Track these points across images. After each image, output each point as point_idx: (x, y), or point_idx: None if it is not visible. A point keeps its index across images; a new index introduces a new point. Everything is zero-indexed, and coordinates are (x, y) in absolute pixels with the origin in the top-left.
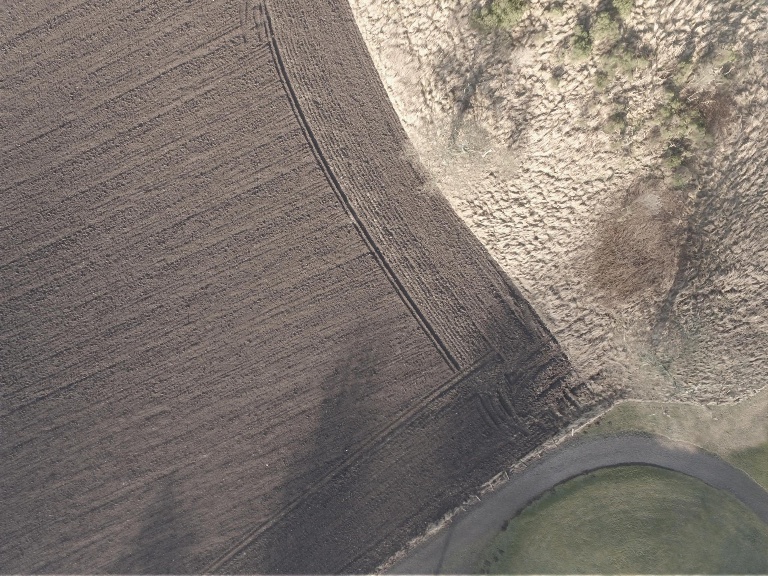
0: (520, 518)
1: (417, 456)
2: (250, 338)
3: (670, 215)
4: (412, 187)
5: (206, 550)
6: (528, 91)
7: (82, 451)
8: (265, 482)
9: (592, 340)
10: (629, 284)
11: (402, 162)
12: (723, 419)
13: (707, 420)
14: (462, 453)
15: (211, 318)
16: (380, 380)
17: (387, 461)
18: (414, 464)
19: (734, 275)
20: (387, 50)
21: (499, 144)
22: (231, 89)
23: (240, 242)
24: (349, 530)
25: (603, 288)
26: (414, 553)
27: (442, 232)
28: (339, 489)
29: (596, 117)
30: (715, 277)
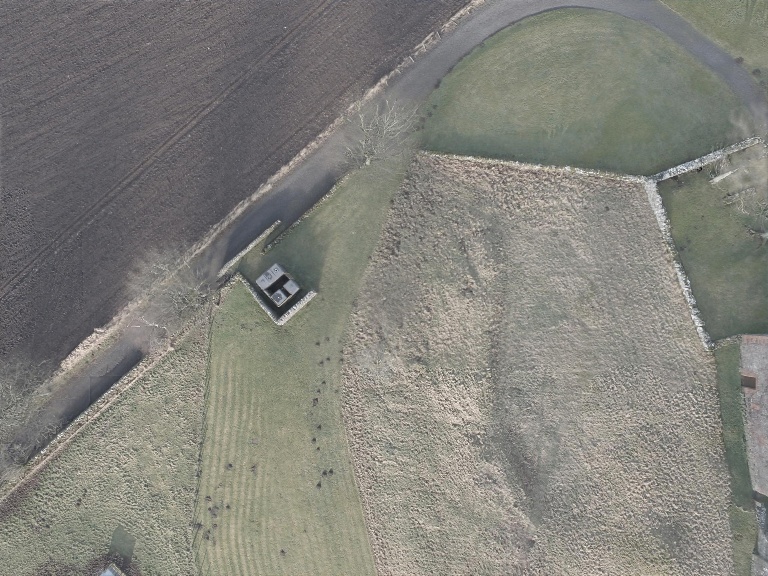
0: (452, 73)
1: (353, 26)
2: None
3: None
4: None
5: (151, 135)
6: None
7: (27, 48)
8: (207, 65)
9: None
10: None
11: None
12: None
13: None
14: (395, 19)
15: None
16: None
17: (324, 34)
18: (350, 34)
19: None
20: None
21: None
22: None
23: None
24: (290, 104)
25: None
26: (352, 120)
27: None
28: (279, 66)
29: None
30: None
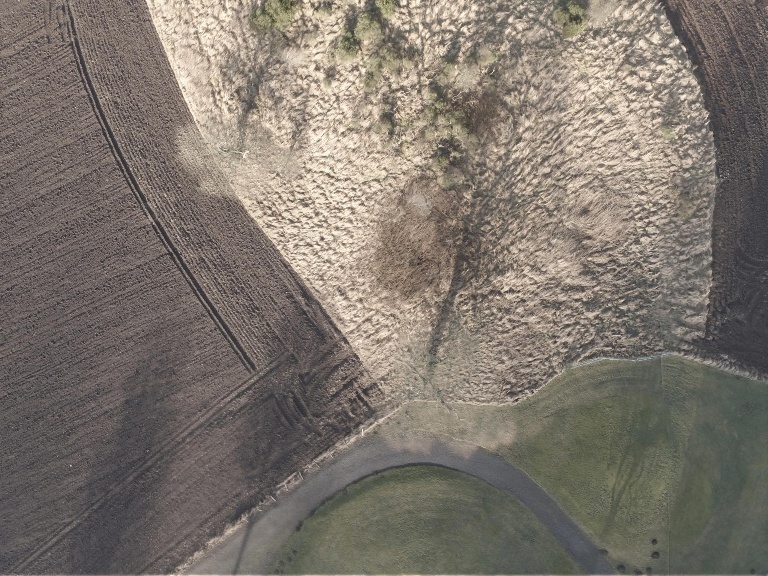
0: (313, 518)
1: (215, 456)
2: (54, 339)
3: (445, 215)
4: (207, 188)
5: (12, 551)
6: (305, 91)
7: None
8: (69, 483)
9: (380, 340)
10: (407, 284)
11: (197, 162)
12: (504, 419)
13: (489, 420)
14: (258, 453)
15: (16, 319)
16: (179, 381)
17: (187, 462)
18: (212, 464)
19: (511, 275)
20: (179, 50)
21: (282, 144)
22: (35, 89)
23: (44, 243)
24: (150, 530)
25: (385, 288)
26: (212, 553)
27: (236, 233)
28: (141, 490)
29: (367, 117)
30: (493, 277)
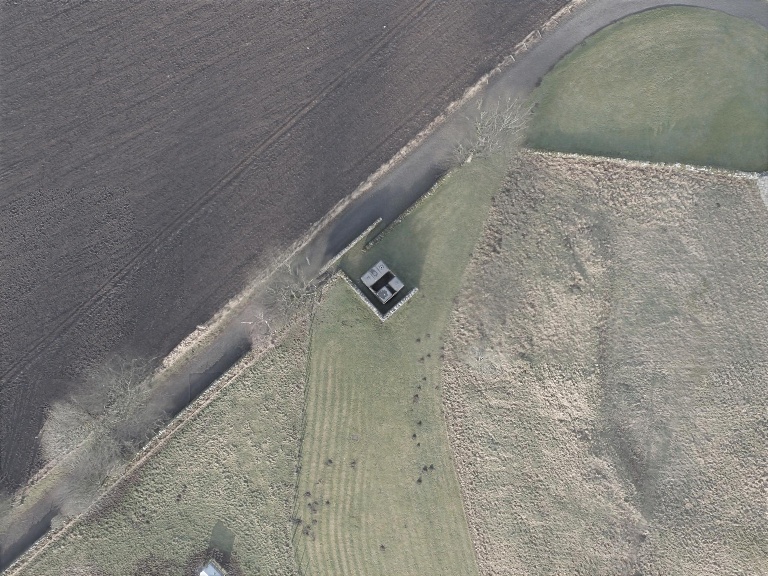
0: (553, 71)
1: (453, 25)
2: None
3: None
4: None
5: (251, 134)
6: None
7: (127, 48)
8: (306, 64)
9: None
10: None
11: None
12: None
13: None
14: (496, 18)
15: None
16: None
17: (424, 33)
18: (450, 33)
19: None
20: None
21: None
22: None
23: None
24: (389, 103)
25: None
26: (453, 118)
27: None
28: (378, 65)
29: None
30: None
